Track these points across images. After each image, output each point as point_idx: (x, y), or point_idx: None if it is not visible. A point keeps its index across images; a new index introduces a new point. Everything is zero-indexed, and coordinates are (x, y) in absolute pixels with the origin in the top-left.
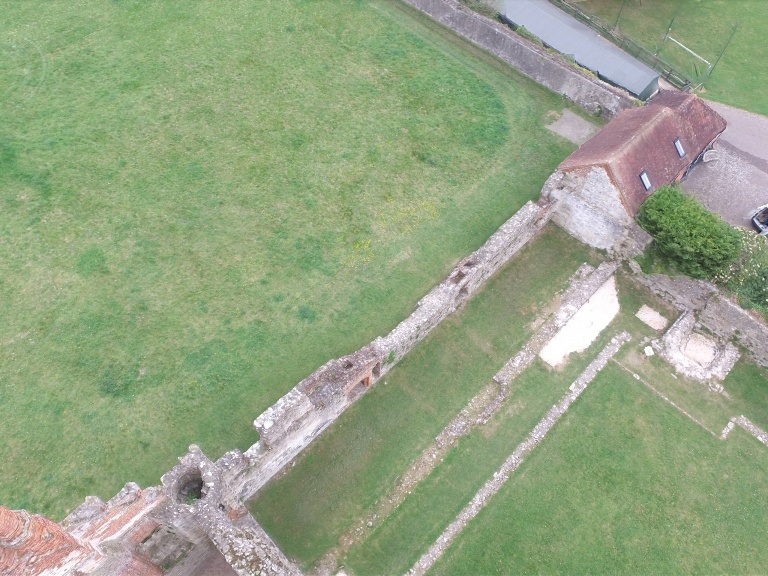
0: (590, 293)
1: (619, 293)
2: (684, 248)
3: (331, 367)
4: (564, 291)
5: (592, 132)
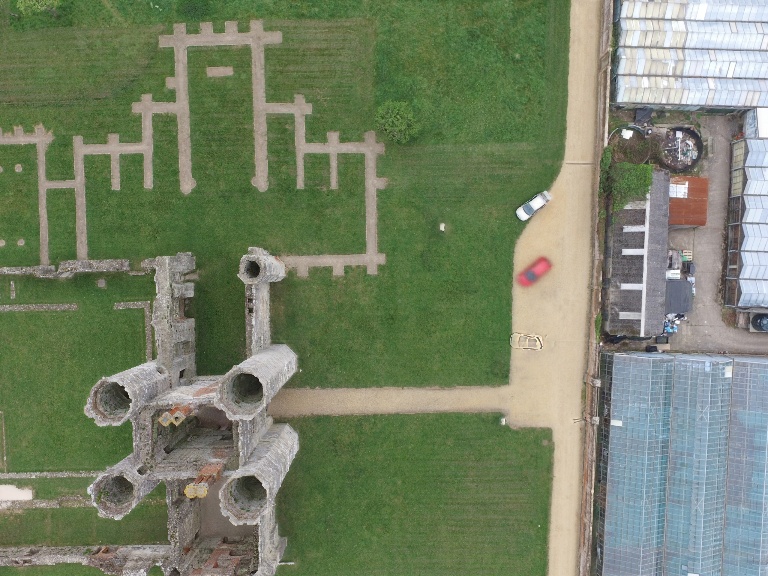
0: None
1: None
2: None
3: (107, 571)
4: None
5: None
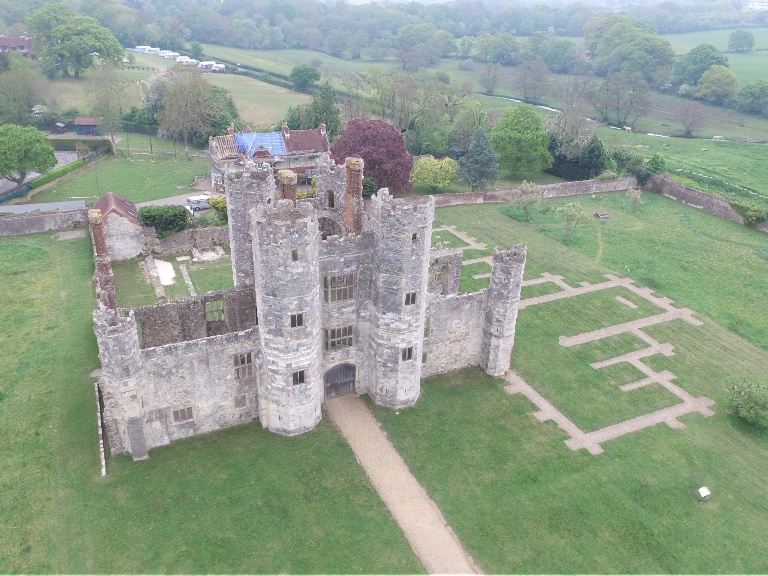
0: (154, 265)
1: (164, 260)
2: (170, 215)
3: None
4: (144, 270)
5: (81, 232)
